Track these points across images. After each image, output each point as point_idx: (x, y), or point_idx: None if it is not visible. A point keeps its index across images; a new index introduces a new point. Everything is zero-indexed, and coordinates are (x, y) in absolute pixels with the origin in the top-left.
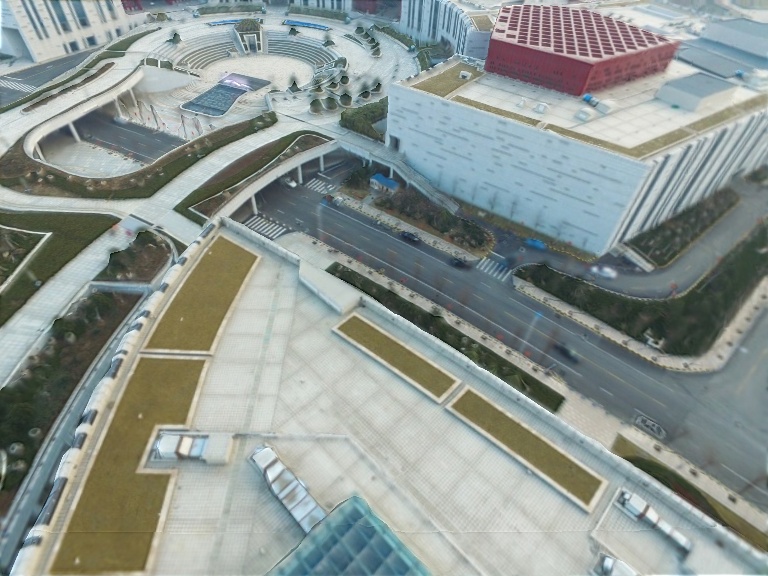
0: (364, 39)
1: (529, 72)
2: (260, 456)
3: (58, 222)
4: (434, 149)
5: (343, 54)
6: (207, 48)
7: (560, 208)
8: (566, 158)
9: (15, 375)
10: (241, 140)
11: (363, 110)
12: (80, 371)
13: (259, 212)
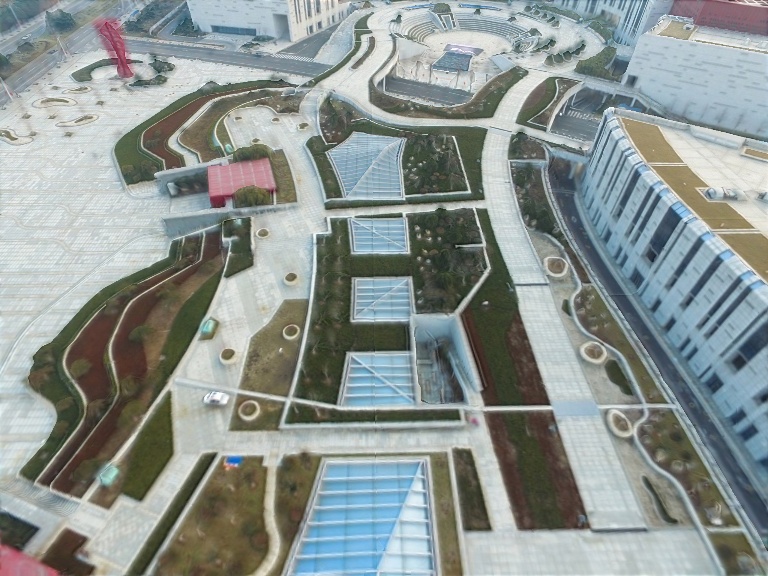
0: (535, 15)
1: (737, 23)
2: None
3: (450, 131)
4: (671, 82)
5: (528, 27)
6: (417, 26)
7: None
8: None
9: (518, 201)
10: (519, 83)
11: (593, 61)
12: (546, 202)
13: (551, 130)
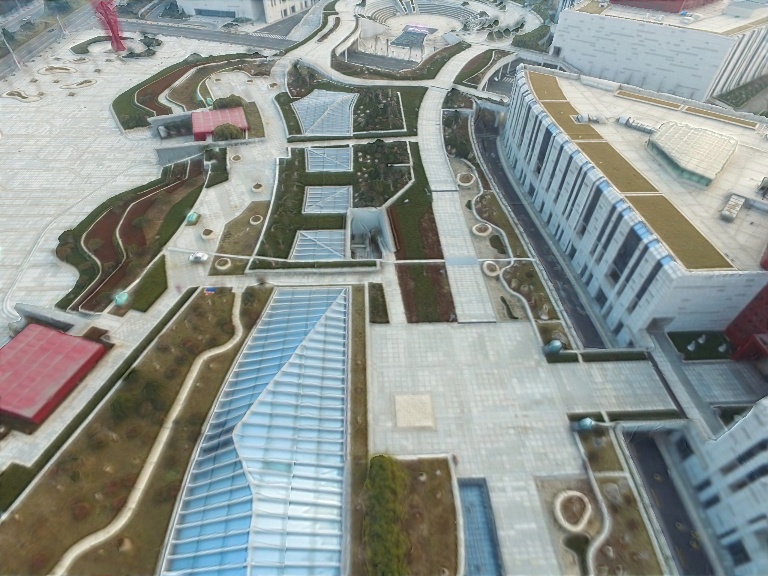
0: (487, 1)
1: (643, 1)
2: (624, 116)
3: (396, 89)
4: (588, 51)
5: (479, 10)
6: (380, 10)
7: (676, 76)
8: (683, 41)
9: (444, 137)
10: (461, 53)
11: (527, 35)
12: (468, 139)
13: None
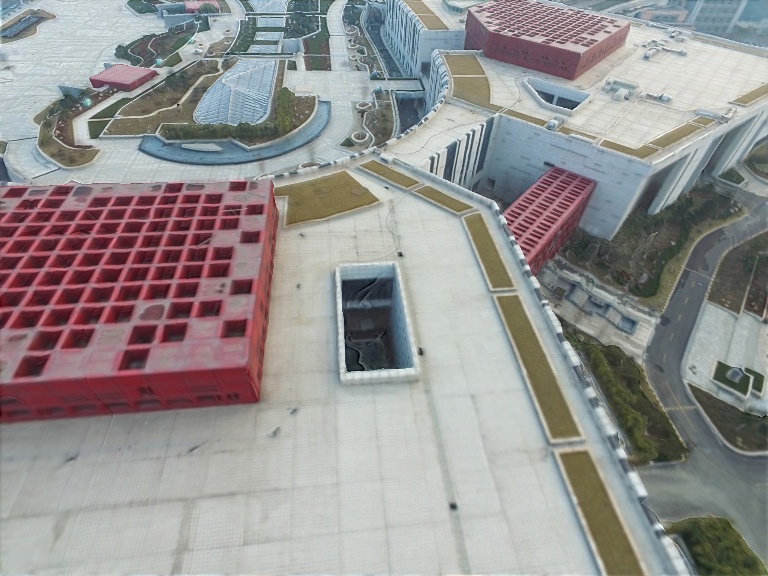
0: None
1: None
2: None
3: None
4: None
5: None
6: None
7: None
8: None
9: None
10: None
11: None
12: None
13: None
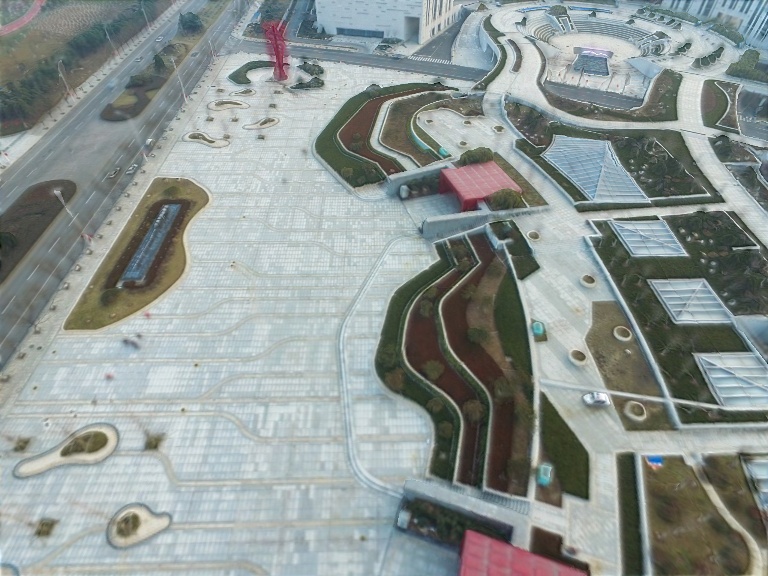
0: (650, 18)
1: None
2: None
3: (646, 134)
4: None
5: (649, 29)
6: (538, 29)
7: None
8: None
9: None
10: (682, 86)
11: (746, 64)
12: None
13: None
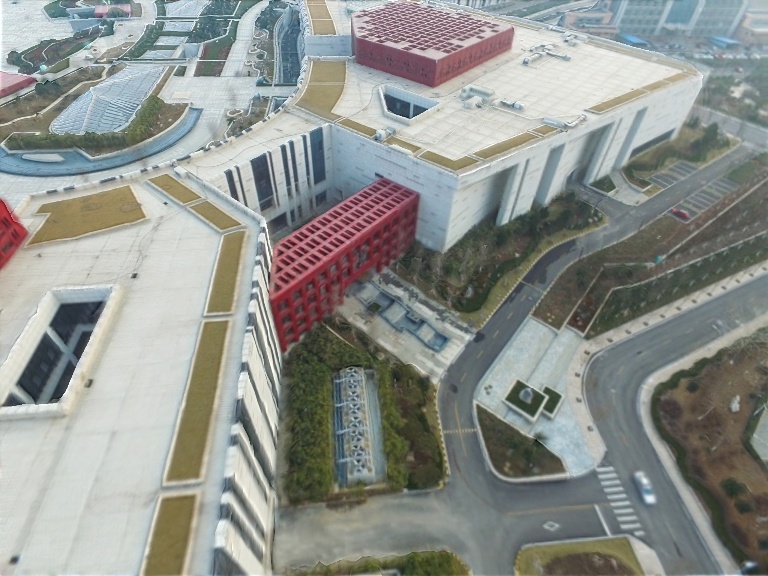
0: None
1: None
2: None
3: None
4: None
5: None
6: None
7: None
8: None
9: None
10: None
11: None
12: (274, 22)
13: None
